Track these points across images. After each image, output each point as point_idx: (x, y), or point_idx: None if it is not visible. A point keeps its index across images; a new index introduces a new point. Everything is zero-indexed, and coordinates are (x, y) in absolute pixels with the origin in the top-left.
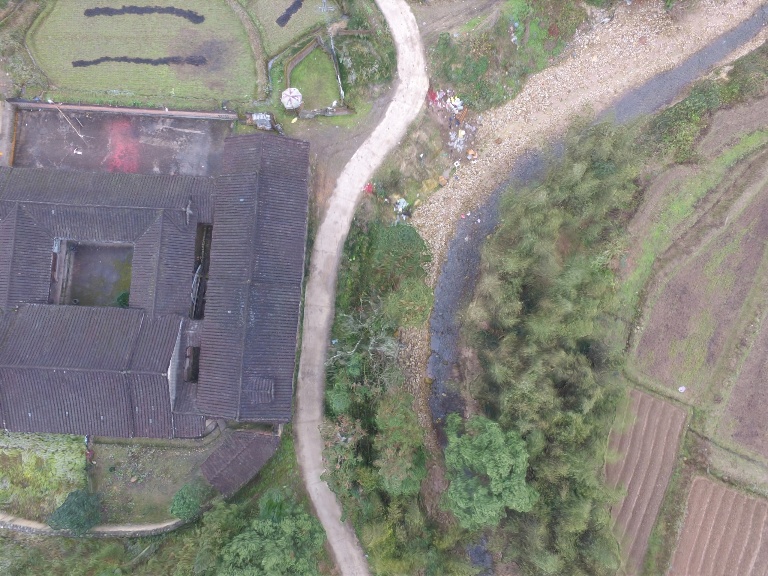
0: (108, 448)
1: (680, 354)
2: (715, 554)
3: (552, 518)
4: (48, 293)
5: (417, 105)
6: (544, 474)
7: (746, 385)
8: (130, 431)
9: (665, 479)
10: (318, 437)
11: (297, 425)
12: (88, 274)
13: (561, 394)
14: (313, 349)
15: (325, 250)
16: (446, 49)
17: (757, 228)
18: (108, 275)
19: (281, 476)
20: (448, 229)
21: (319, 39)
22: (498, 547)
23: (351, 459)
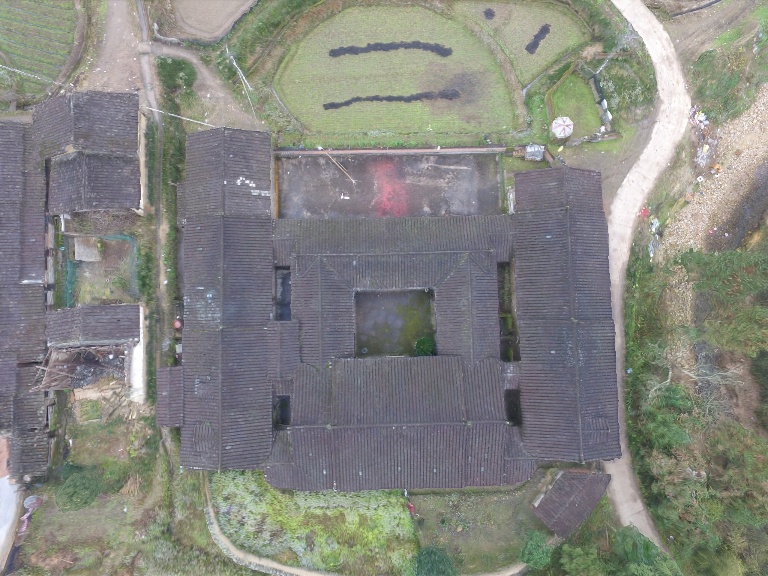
0: (426, 499)
1: None
2: None
3: None
4: (354, 346)
5: (682, 124)
6: None
7: None
8: (463, 481)
9: None
10: (625, 469)
11: None
12: (372, 321)
13: None
14: None
15: None
16: (708, 66)
17: None
18: (393, 321)
19: (597, 512)
20: (698, 245)
21: (580, 64)
22: None
23: (703, 493)
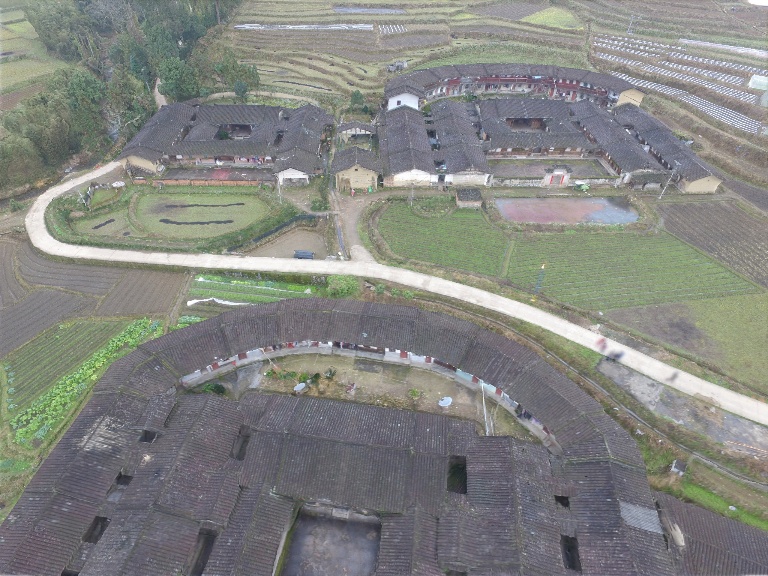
0: None
1: None
2: None
3: None
4: None
5: None
6: None
7: None
8: None
9: None
10: None
11: None
12: None
13: None
14: None
15: None
16: None
17: None
18: None
19: None
20: None
21: None
22: None
23: None
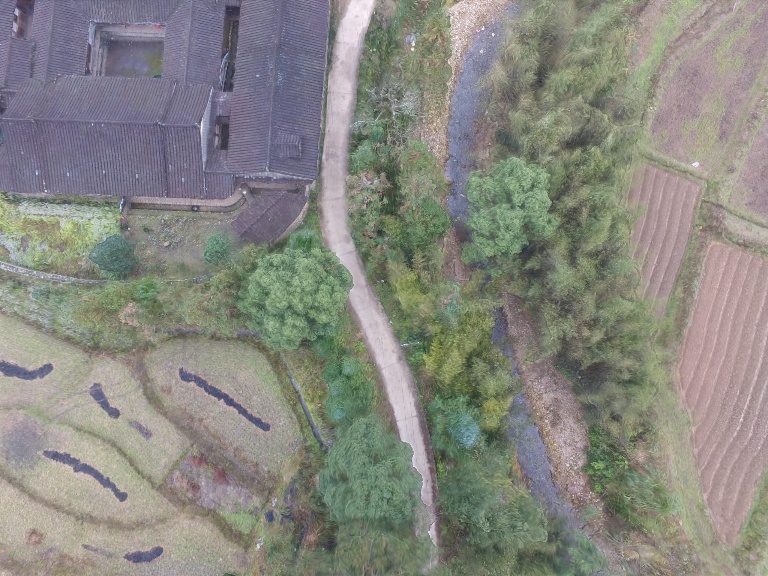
0: (141, 217)
1: (693, 132)
2: (733, 314)
3: (573, 247)
4: (84, 70)
5: None
6: (564, 204)
7: (758, 157)
8: (164, 189)
9: (681, 248)
10: (342, 213)
11: (322, 202)
12: (120, 67)
13: (578, 145)
14: (336, 132)
15: (347, 42)
16: None
17: (765, 14)
18: (139, 67)
19: None
20: (463, 42)
21: None
22: (520, 288)
23: (377, 202)
